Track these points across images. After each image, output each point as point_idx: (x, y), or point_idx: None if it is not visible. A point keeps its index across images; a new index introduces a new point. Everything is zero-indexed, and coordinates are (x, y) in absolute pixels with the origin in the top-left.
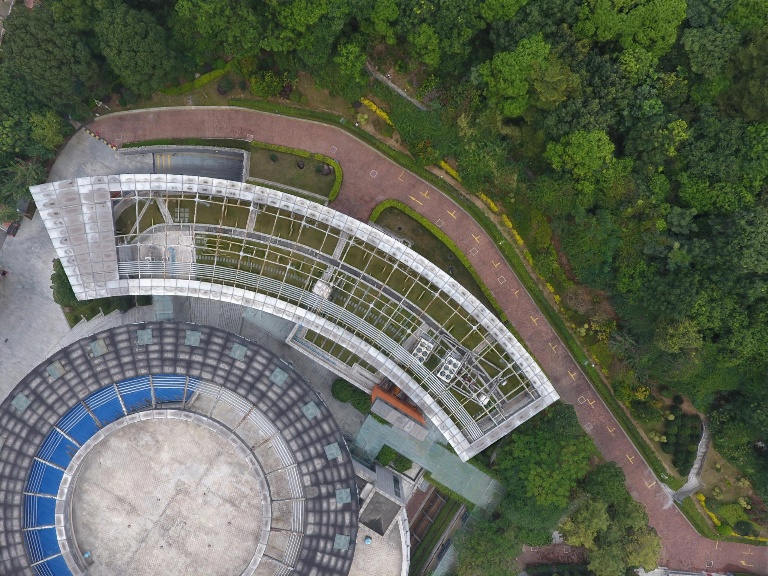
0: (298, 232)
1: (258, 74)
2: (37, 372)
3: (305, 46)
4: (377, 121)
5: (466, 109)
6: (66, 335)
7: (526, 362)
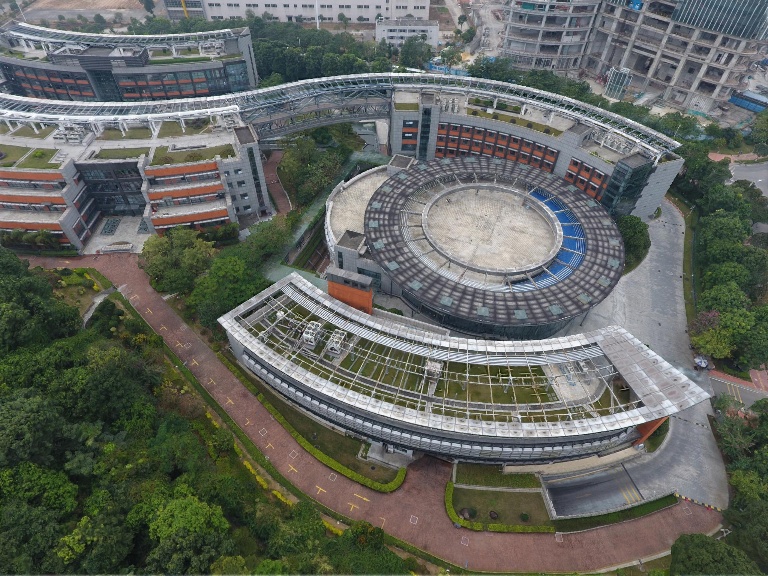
0: None
1: None
2: (615, 280)
3: None
4: (426, 575)
5: (325, 575)
6: None
7: (247, 339)
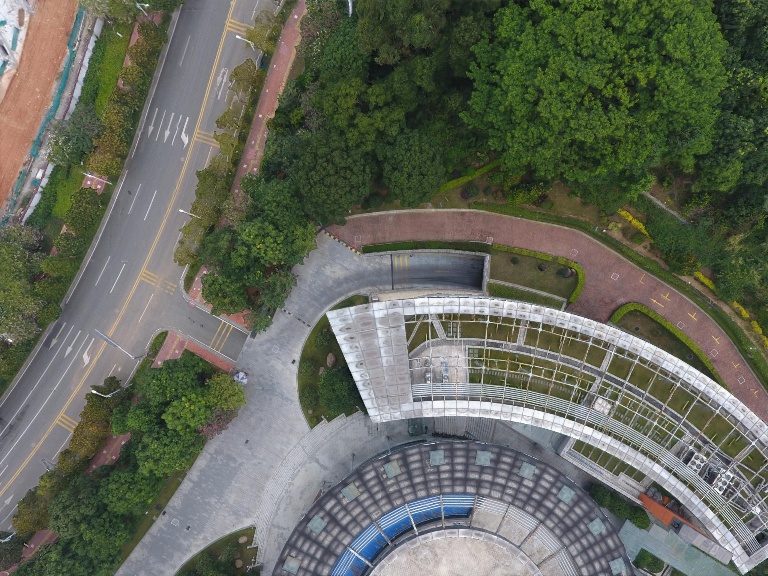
0: (567, 345)
1: (524, 188)
2: (332, 494)
3: (599, 173)
4: (629, 229)
5: (746, 230)
6: (306, 436)
7: None
